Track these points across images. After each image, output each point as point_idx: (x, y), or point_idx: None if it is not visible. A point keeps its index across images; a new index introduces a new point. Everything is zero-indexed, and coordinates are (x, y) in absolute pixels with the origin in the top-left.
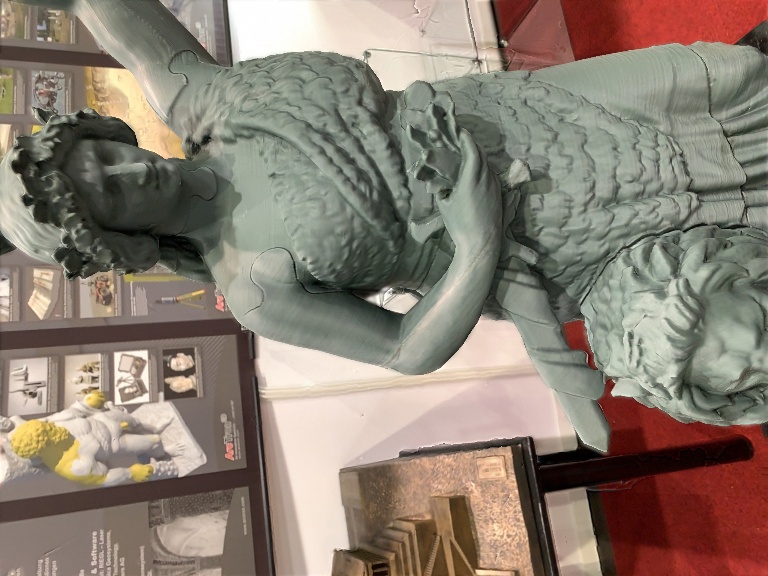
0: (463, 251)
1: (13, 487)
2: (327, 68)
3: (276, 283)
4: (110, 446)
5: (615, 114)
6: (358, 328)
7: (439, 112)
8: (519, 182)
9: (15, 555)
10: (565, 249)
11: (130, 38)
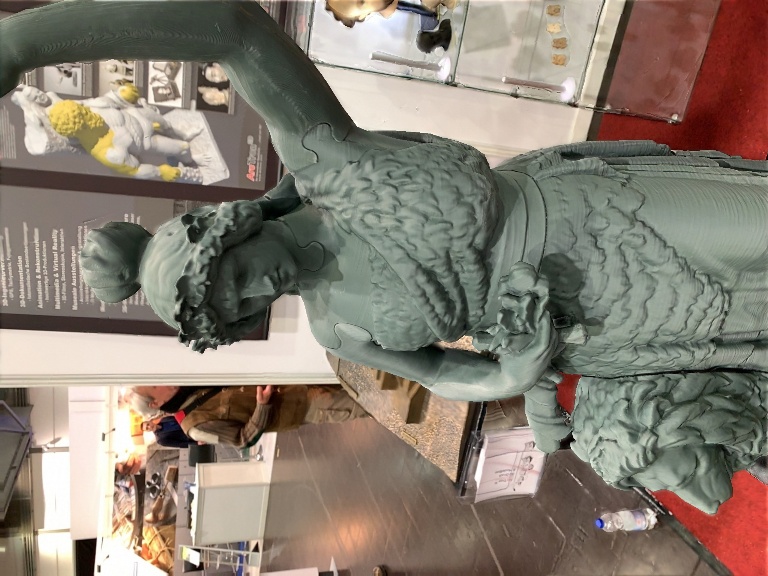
0: (505, 382)
1: (53, 159)
2: (453, 208)
3: (353, 341)
4: (142, 142)
5: (693, 267)
6: (406, 371)
7: (533, 297)
8: (573, 343)
9: (58, 217)
10: (587, 367)
11: (270, 110)
